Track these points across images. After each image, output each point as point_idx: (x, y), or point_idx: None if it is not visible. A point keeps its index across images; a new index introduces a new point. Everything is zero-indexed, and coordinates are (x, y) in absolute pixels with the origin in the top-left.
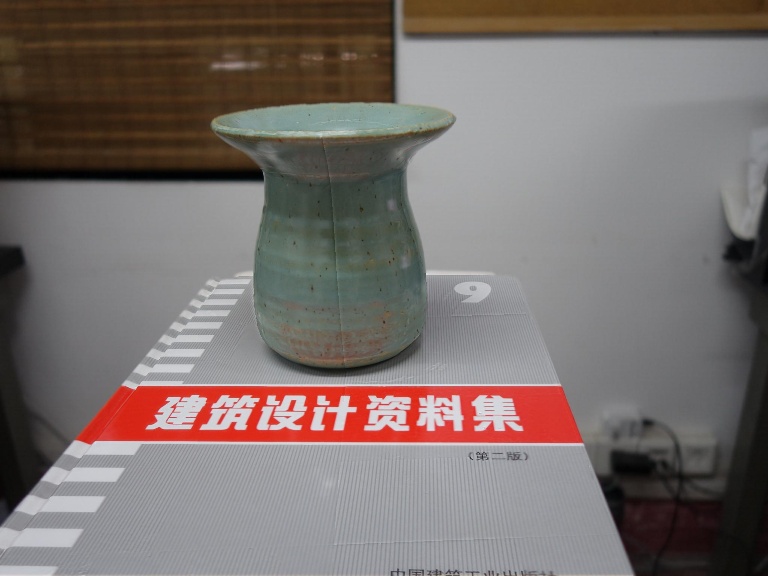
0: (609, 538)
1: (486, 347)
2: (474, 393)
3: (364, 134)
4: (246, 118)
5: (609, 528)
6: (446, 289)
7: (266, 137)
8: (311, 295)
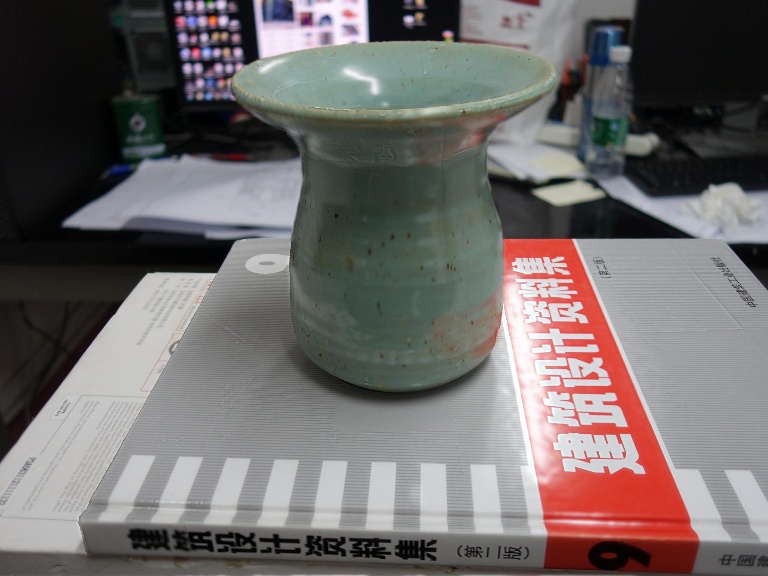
0: (670, 241)
1: None
2: (510, 272)
3: None
4: None
5: (661, 240)
6: (264, 278)
7: None
8: None
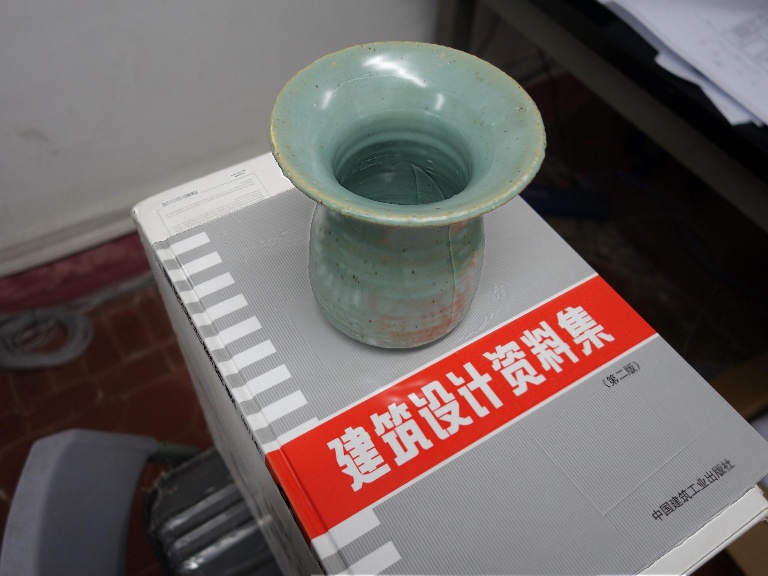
0: (731, 414)
1: (512, 249)
2: (552, 313)
3: (523, 185)
4: (287, 138)
5: (725, 405)
6: None
7: (439, 225)
8: (431, 306)
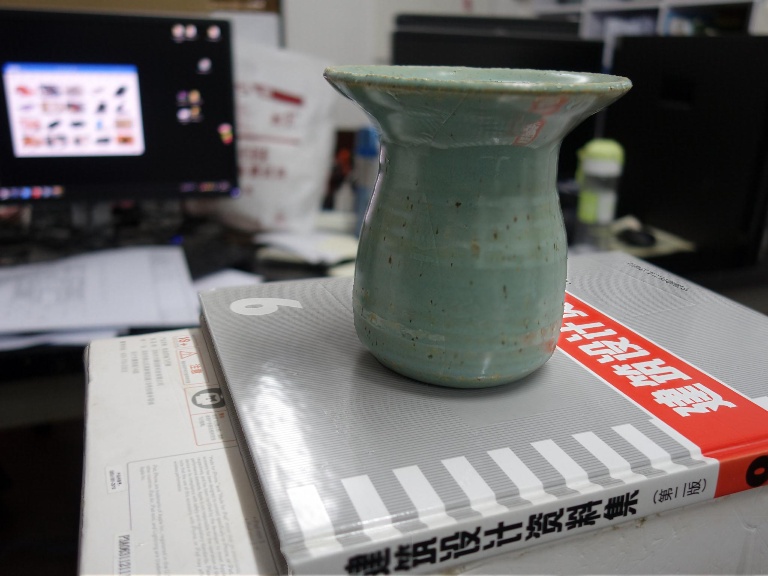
0: None
1: None
2: None
3: None
4: None
5: None
6: (265, 318)
7: None
8: None
